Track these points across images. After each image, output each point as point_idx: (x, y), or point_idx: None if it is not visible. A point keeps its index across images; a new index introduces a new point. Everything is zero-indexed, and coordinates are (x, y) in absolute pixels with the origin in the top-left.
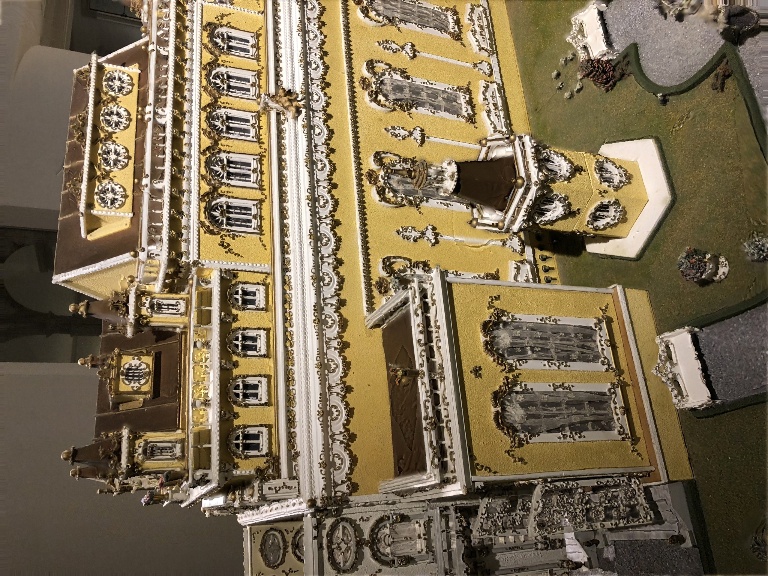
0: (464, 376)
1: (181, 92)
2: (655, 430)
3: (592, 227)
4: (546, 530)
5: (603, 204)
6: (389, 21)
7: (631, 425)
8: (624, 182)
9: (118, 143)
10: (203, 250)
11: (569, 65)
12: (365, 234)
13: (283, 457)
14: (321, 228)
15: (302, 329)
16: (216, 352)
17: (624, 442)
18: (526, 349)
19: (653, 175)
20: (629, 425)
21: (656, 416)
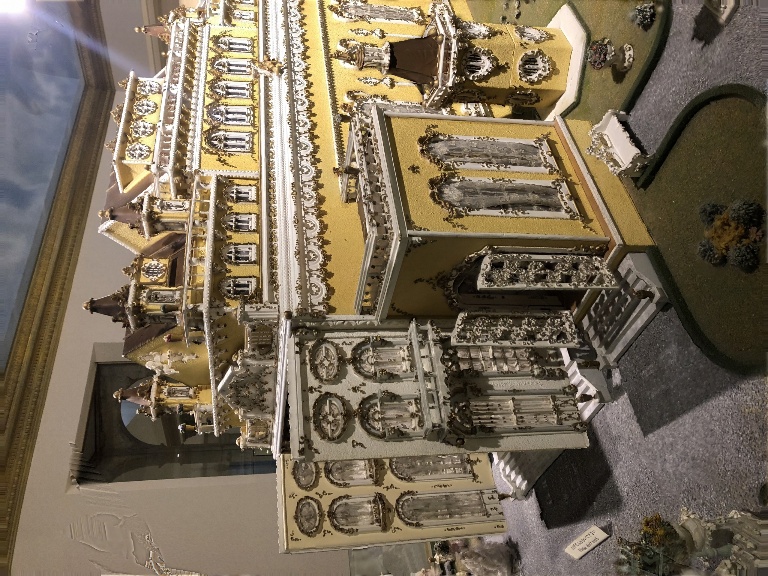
0: (402, 172)
1: (191, 76)
2: (605, 208)
3: (526, 80)
4: (495, 283)
5: (529, 57)
6: (360, 17)
7: (581, 209)
8: (545, 37)
9: (146, 122)
10: (203, 164)
11: (510, 5)
12: (341, 143)
13: (265, 287)
14: (301, 139)
15: (282, 201)
16: (210, 224)
17: (575, 221)
18: (465, 158)
19: (571, 28)
20: (577, 207)
21: (607, 201)
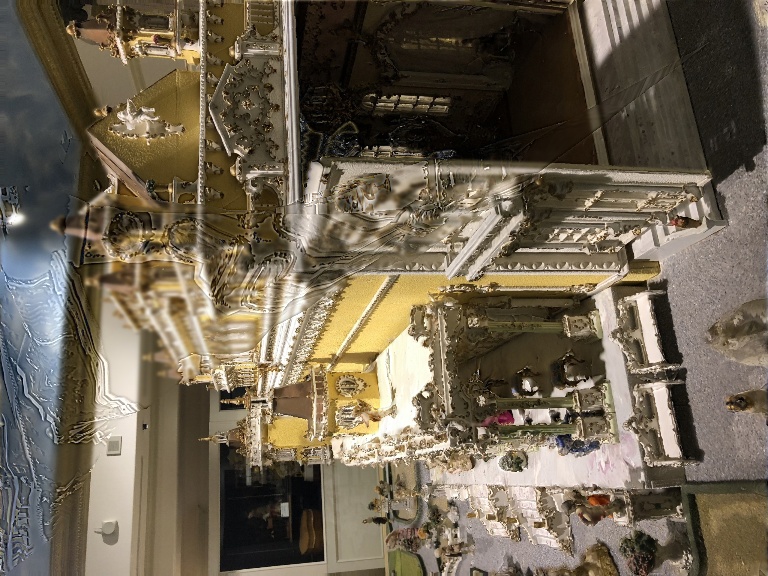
0: None
1: None
2: None
3: None
4: None
5: None
6: None
7: None
8: None
9: None
10: None
11: None
12: None
13: None
14: None
15: None
16: None
17: None
18: None
19: None
20: None
21: None
